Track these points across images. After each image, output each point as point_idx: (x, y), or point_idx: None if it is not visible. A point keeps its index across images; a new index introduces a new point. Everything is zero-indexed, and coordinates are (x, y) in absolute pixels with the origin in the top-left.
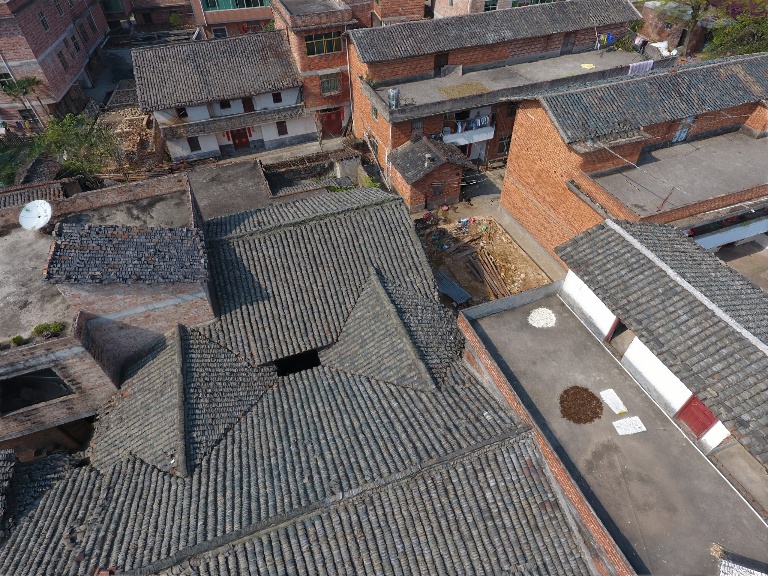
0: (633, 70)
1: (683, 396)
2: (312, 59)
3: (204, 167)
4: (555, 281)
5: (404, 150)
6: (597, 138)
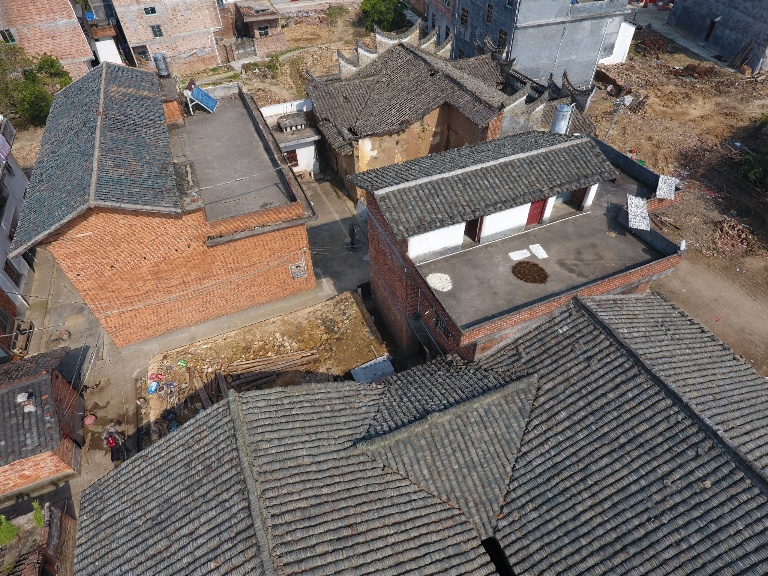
0: (0, 152)
1: (526, 212)
2: None
3: None
4: (409, 258)
5: None
6: (182, 190)
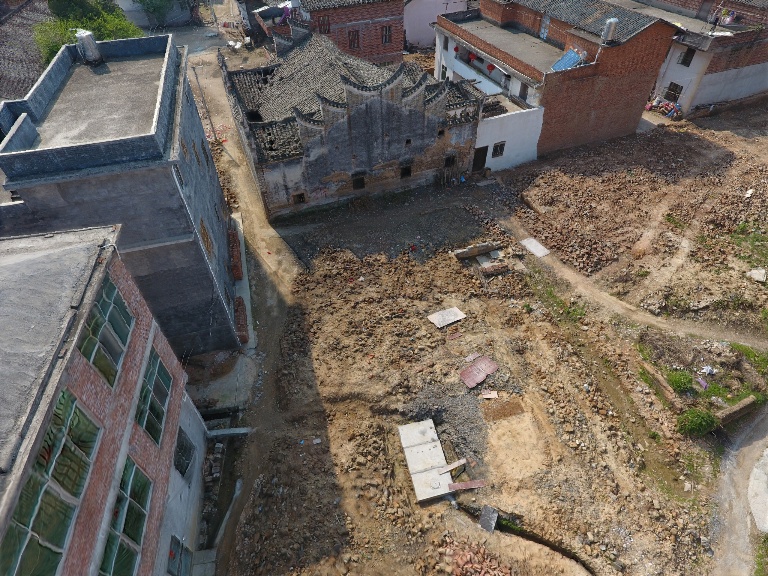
0: None
1: None
2: None
3: None
4: None
5: None
6: None
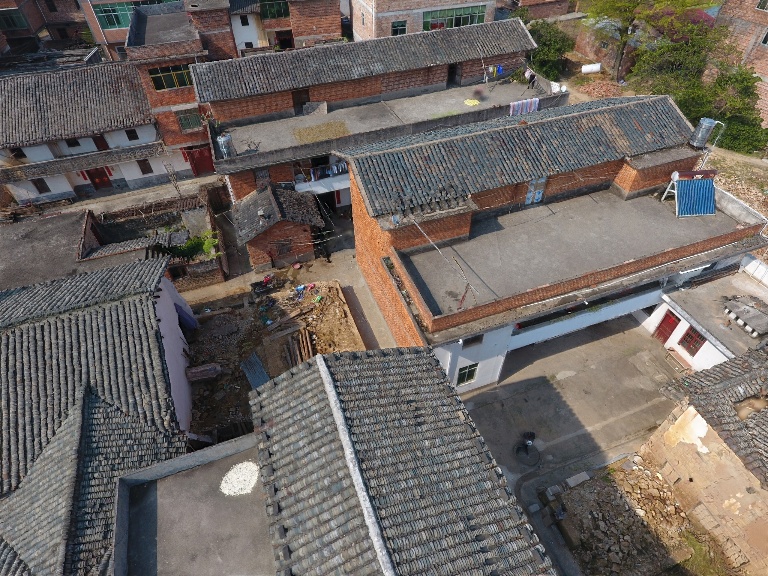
0: (515, 109)
1: None
2: (163, 94)
3: (55, 210)
4: None
5: (248, 201)
6: (409, 210)
